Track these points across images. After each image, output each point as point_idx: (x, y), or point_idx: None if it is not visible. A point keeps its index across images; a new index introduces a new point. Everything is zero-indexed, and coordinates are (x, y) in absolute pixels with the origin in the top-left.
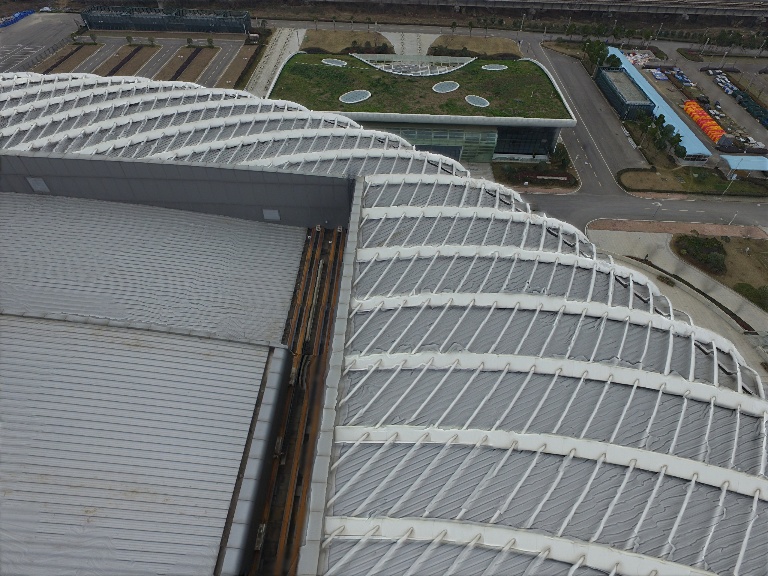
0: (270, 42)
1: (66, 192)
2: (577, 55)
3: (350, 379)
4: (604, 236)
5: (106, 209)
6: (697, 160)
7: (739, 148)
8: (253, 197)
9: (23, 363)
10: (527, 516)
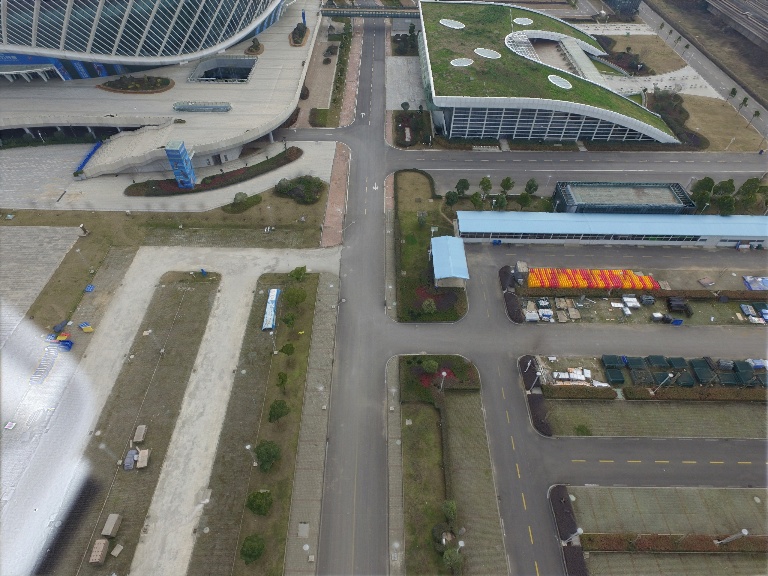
0: (608, 24)
1: None
2: None
3: None
4: (328, 148)
5: None
6: None
7: None
8: None
9: None
10: None
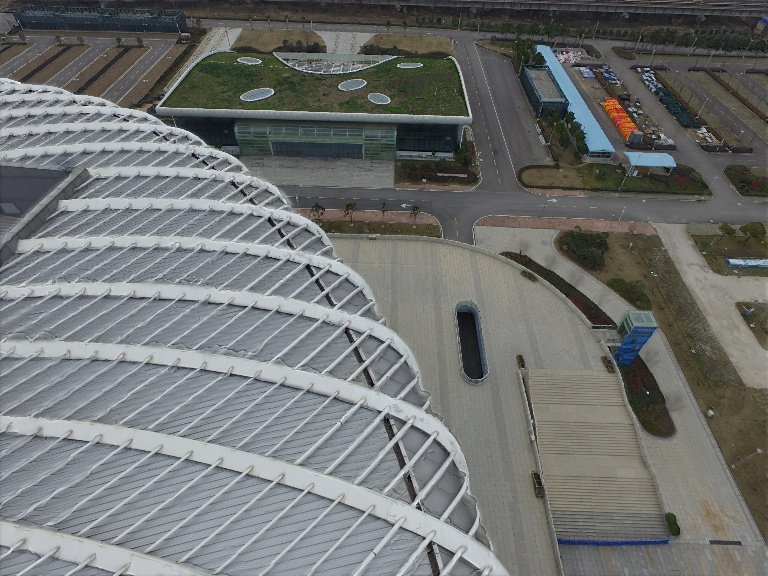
0: (202, 41)
1: None
2: (509, 53)
3: None
4: (491, 232)
5: None
6: (602, 157)
7: (648, 145)
8: None
9: None
10: (1, 501)
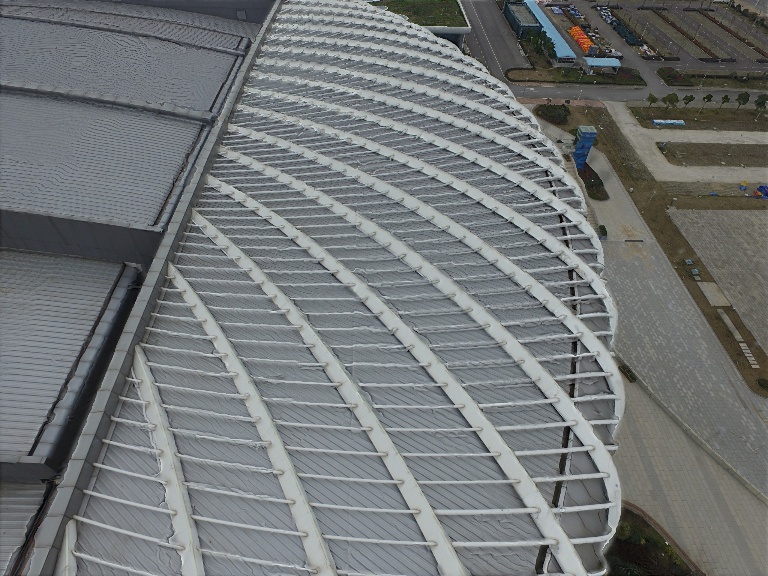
0: None
1: (130, 1)
2: None
3: (273, 27)
4: None
5: (152, 9)
6: (567, 62)
7: (603, 56)
8: (231, 2)
9: (138, 27)
10: None
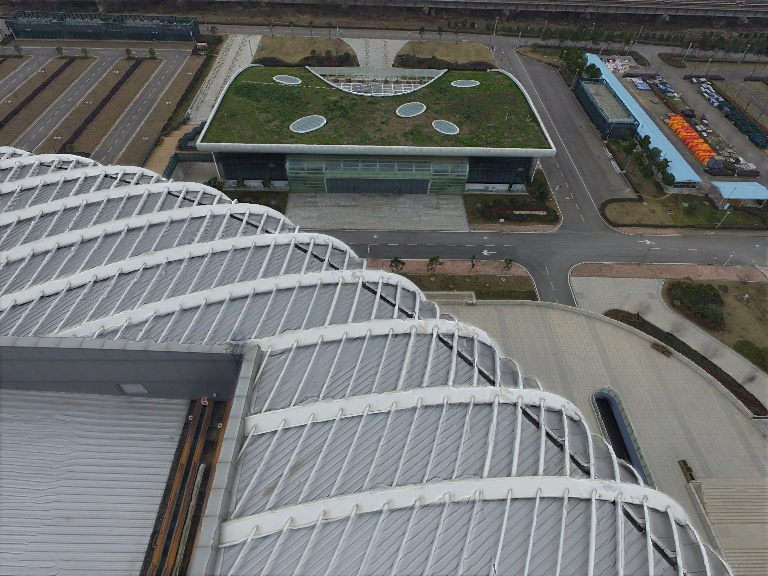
0: (220, 51)
1: None
2: (554, 62)
3: None
4: (589, 285)
5: None
6: (686, 187)
7: (729, 170)
8: (100, 373)
9: None
10: None
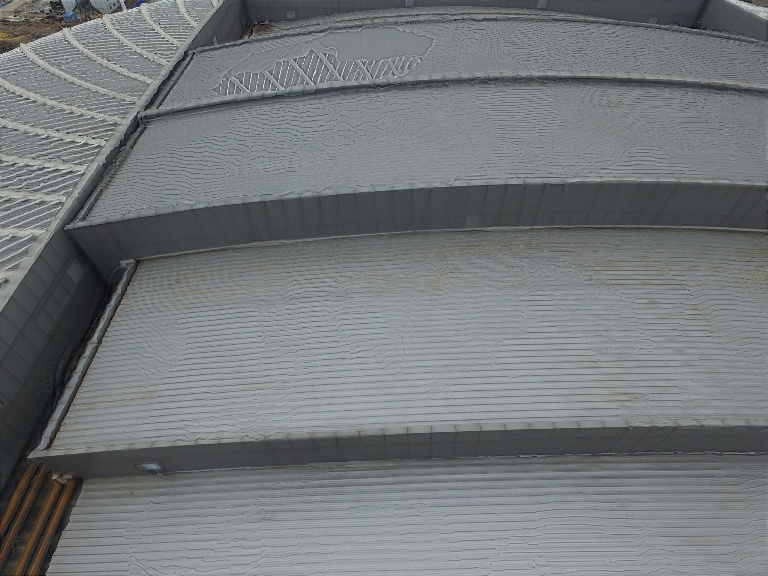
0: None
1: (554, 8)
2: None
3: None
4: None
5: None
6: None
7: None
8: (651, 9)
9: None
10: None
